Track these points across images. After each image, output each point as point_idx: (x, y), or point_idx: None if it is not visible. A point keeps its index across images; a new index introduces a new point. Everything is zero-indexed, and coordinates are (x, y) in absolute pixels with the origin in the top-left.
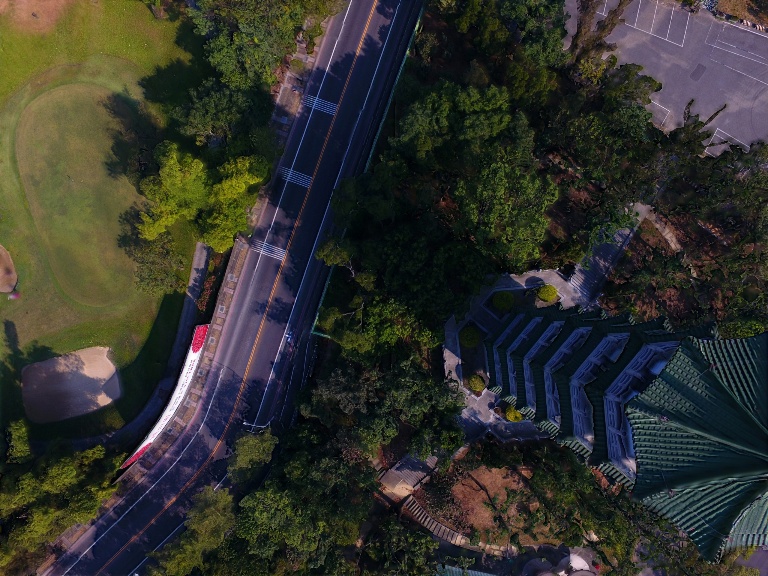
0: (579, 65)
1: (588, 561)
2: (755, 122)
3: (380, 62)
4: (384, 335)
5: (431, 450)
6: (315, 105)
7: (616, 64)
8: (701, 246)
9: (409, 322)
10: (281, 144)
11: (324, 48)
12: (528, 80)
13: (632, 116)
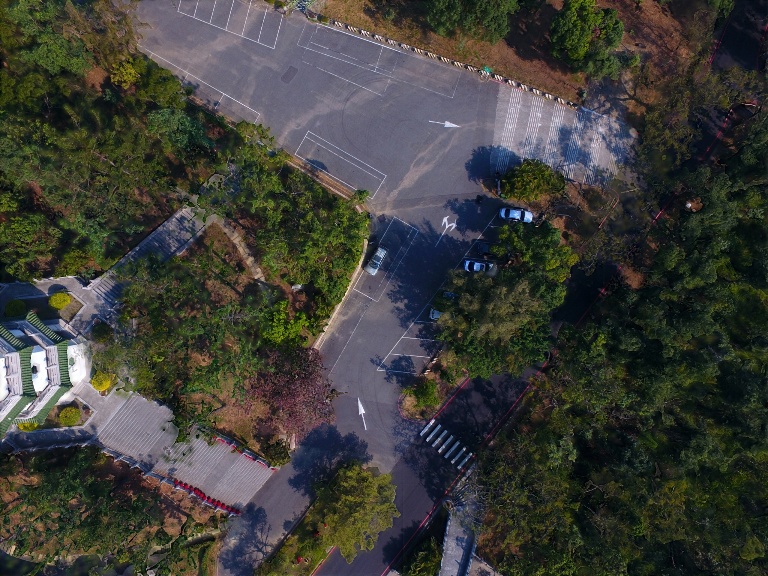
0: (112, 70)
1: (154, 569)
2: (346, 124)
3: None
4: None
5: None
6: None
7: (206, 67)
8: None
9: None
10: None
11: None
12: (14, 86)
13: (165, 121)
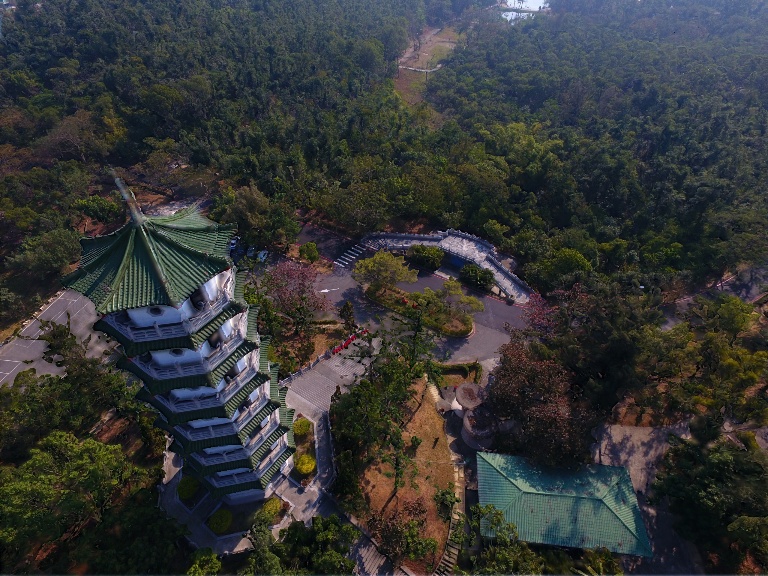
0: None
1: None
2: None
3: None
4: None
5: (342, 553)
6: None
7: None
8: None
9: None
10: None
11: None
12: None
13: None
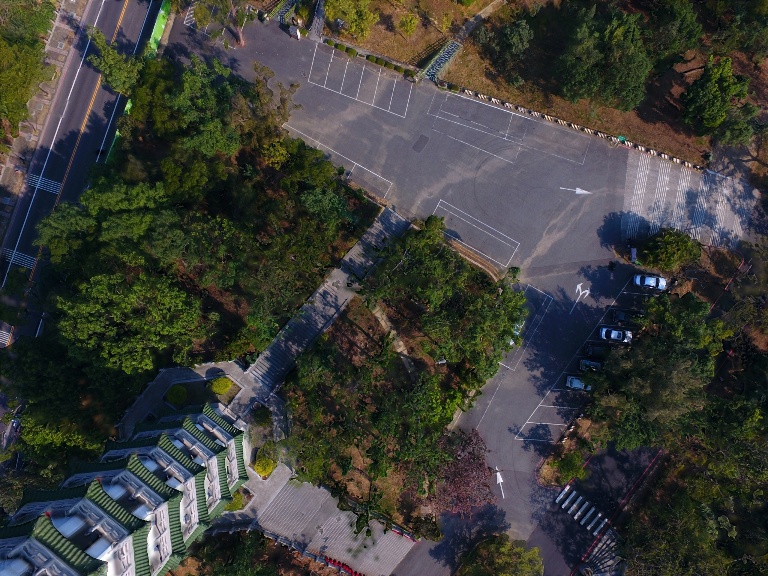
0: (262, 150)
1: None
2: (478, 192)
3: (105, 139)
4: (36, 439)
5: None
6: (39, 184)
7: (338, 137)
8: (413, 322)
9: (40, 432)
10: (3, 225)
11: (48, 126)
12: (181, 175)
13: (316, 200)
